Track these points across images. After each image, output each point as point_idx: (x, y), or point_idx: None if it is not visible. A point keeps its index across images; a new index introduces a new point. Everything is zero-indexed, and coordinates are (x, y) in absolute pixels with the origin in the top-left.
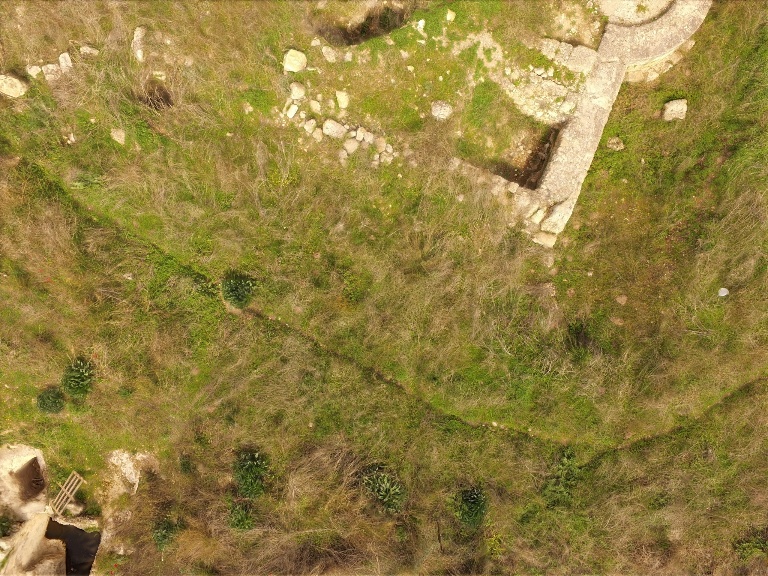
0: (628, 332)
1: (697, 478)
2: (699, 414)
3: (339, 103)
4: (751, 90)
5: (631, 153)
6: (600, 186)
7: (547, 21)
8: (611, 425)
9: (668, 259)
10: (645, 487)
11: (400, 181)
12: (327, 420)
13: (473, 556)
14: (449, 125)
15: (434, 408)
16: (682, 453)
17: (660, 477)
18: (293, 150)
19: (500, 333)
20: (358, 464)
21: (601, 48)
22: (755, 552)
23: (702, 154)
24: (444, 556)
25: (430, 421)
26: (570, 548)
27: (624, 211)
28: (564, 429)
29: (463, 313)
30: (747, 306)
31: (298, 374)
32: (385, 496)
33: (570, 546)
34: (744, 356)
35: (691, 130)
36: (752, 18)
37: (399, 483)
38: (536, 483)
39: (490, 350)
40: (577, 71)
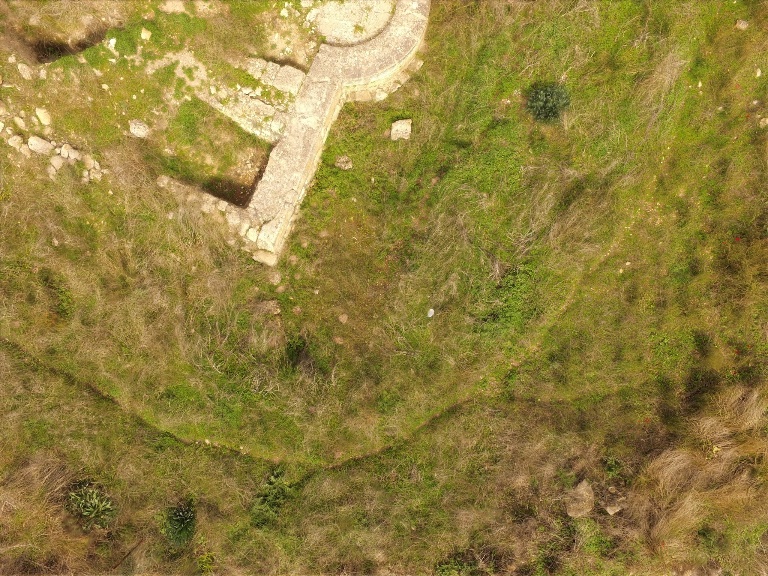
0: (346, 351)
1: (397, 499)
2: (408, 434)
3: (40, 120)
4: (471, 111)
5: (358, 172)
6: (328, 205)
7: (256, 41)
8: (320, 444)
9: (385, 279)
10: (339, 507)
11: (109, 198)
12: (43, 435)
13: (175, 574)
14: (145, 143)
15: (148, 425)
16: (386, 473)
17: (359, 497)
18: (1, 166)
19: (213, 351)
20: (68, 480)
21: (312, 68)
22: (452, 574)
23: (422, 175)
24: (140, 573)
25: (141, 438)
26: (278, 567)
27: (353, 230)
28: (274, 448)
29: (161, 331)
30: (444, 328)
31: (5, 389)
32: (92, 512)
33: (278, 565)
34: (450, 377)
35: (416, 150)
36: (466, 40)
37: (109, 499)
38: (243, 501)
39: (199, 368)
40: (285, 91)
